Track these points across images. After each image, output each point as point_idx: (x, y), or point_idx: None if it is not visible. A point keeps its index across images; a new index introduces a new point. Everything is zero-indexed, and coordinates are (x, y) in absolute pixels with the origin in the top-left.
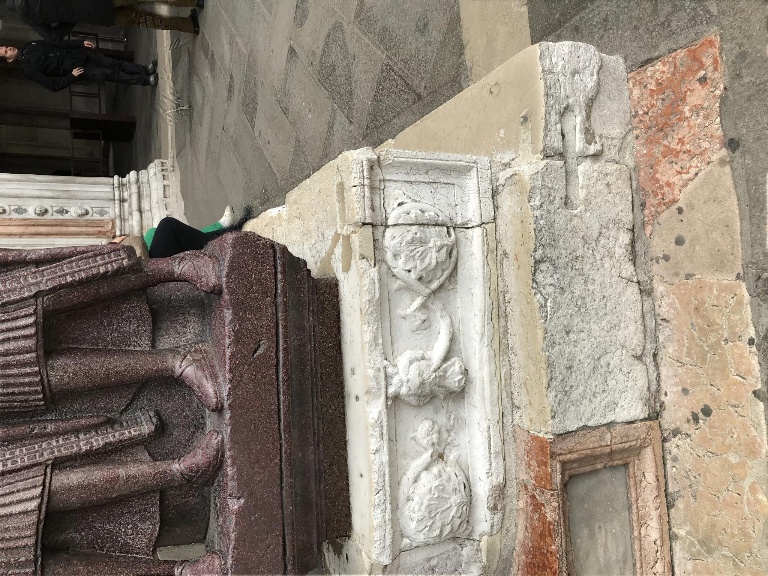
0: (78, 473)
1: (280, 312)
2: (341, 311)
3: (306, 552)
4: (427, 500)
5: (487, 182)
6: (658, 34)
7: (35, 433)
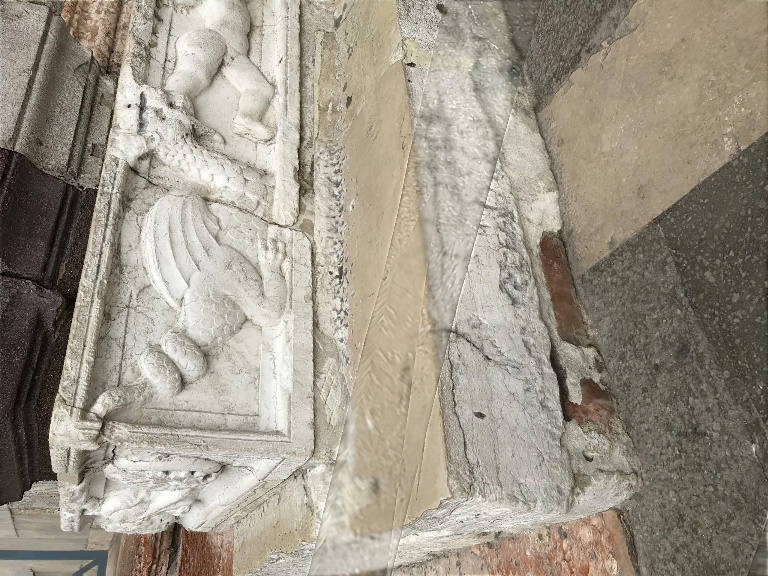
0: None
1: None
2: None
3: (7, 499)
4: (119, 530)
5: (292, 467)
6: (670, 575)
7: None
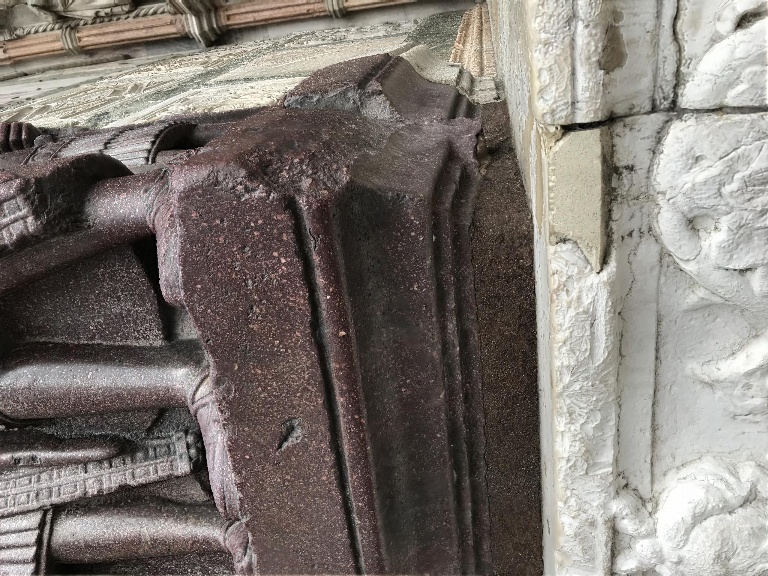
0: (87, 526)
1: (332, 360)
2: (536, 308)
3: None
4: None
5: None
6: None
7: (22, 465)
